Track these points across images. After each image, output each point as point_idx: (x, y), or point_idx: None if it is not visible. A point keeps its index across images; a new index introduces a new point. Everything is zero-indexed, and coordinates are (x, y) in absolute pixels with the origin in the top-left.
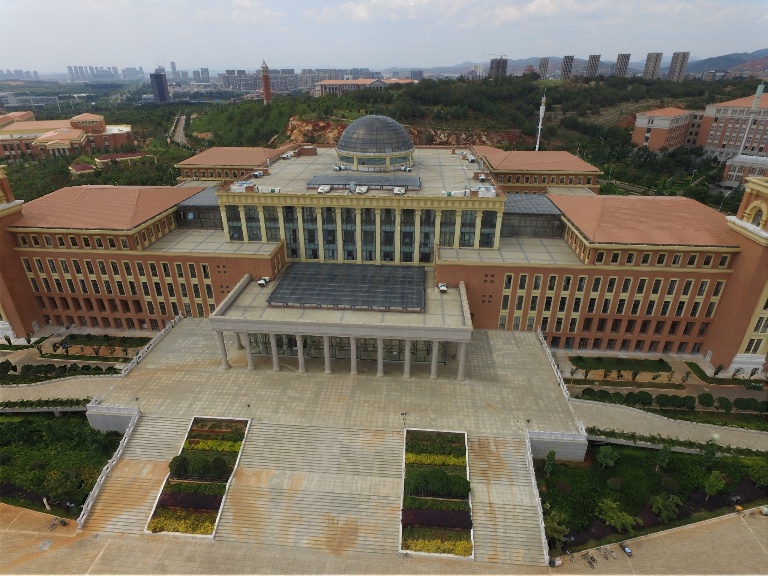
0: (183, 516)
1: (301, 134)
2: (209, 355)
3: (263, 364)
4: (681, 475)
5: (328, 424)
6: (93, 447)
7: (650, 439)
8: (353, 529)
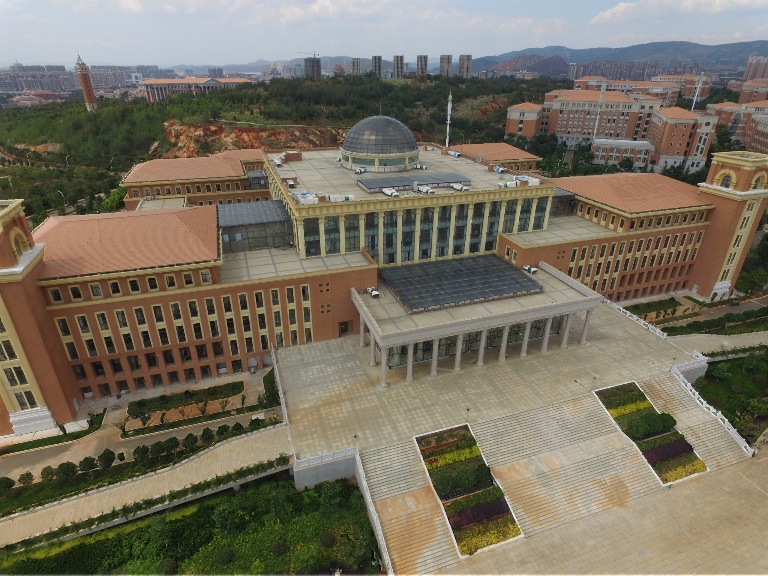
0: (483, 529)
1: (192, 140)
2: (352, 379)
3: (415, 373)
4: (759, 371)
5: (533, 406)
6: (336, 501)
7: (733, 352)
8: (620, 483)
